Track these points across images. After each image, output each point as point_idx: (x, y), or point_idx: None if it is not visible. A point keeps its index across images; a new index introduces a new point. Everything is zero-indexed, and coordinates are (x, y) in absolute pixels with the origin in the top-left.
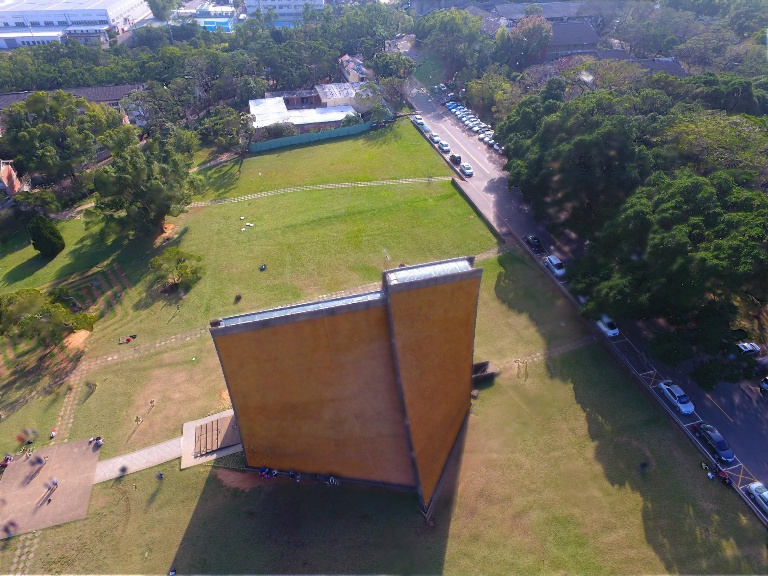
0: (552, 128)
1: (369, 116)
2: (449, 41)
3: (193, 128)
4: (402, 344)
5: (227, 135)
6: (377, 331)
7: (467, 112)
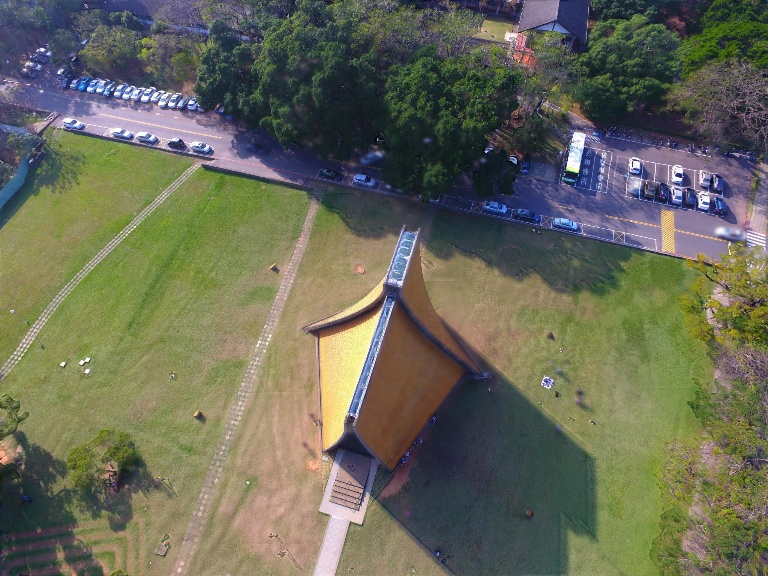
0: (274, 76)
1: None
2: None
3: None
4: (416, 312)
5: None
6: (399, 320)
7: (110, 84)
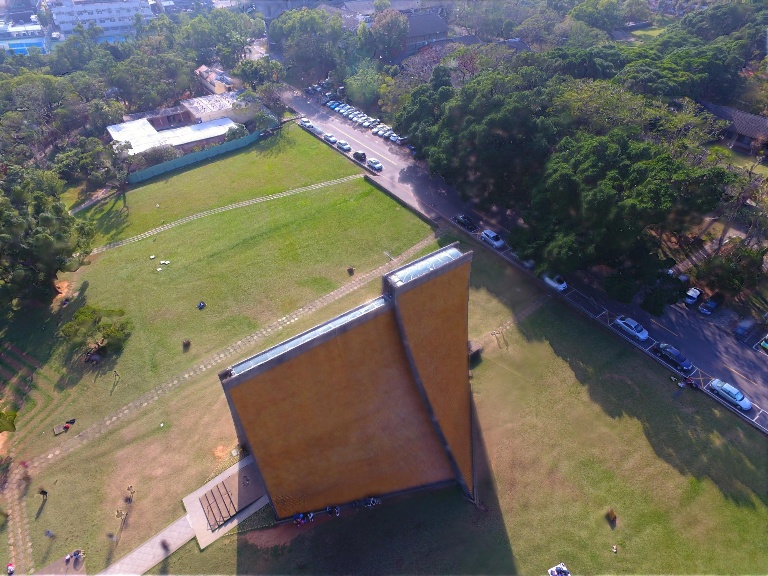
0: (456, 112)
1: (250, 126)
2: (314, 41)
3: (45, 168)
4: (414, 344)
5: (99, 169)
6: (386, 337)
7: (351, 109)
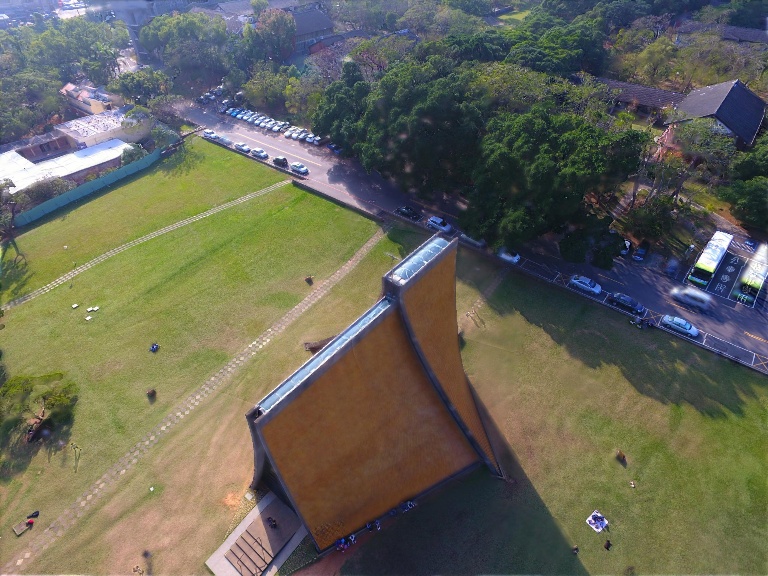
0: (380, 106)
1: (145, 145)
2: (198, 47)
3: None
4: (422, 339)
5: None
6: (394, 338)
7: (255, 115)
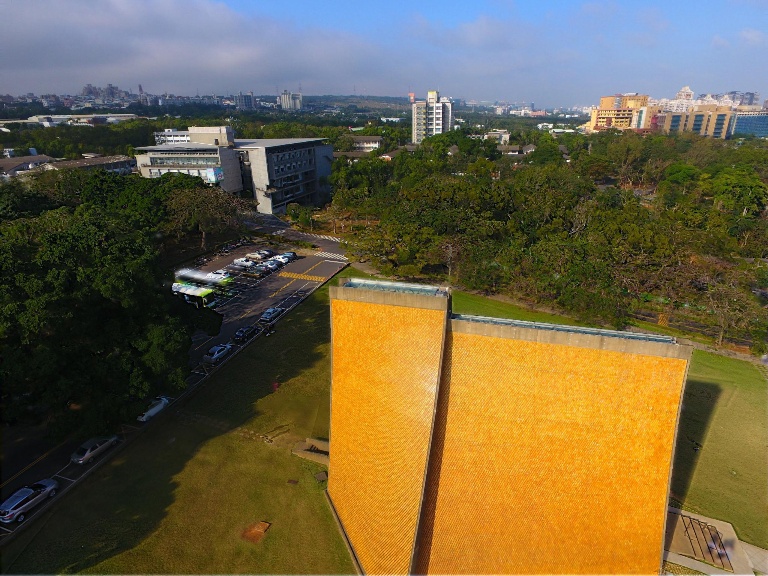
0: None
1: None
2: None
3: None
4: None
5: None
6: None
7: None
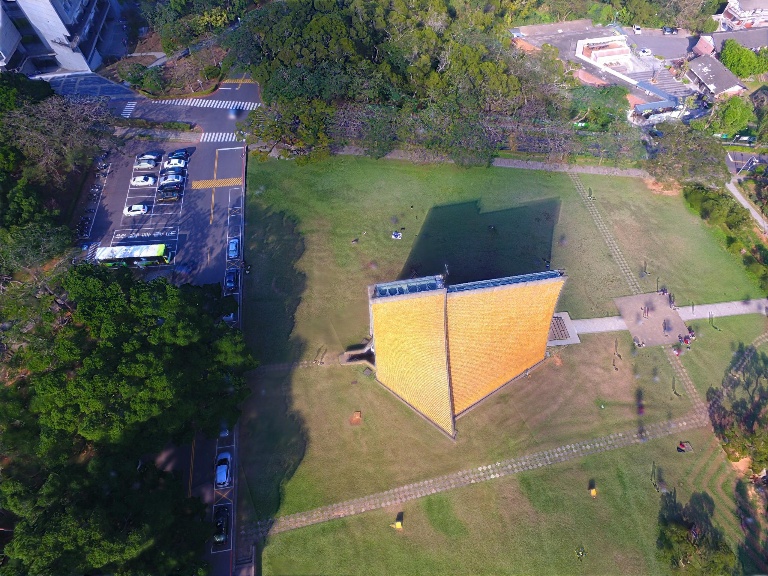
0: None
1: None
2: None
3: None
4: None
5: None
6: None
7: None
